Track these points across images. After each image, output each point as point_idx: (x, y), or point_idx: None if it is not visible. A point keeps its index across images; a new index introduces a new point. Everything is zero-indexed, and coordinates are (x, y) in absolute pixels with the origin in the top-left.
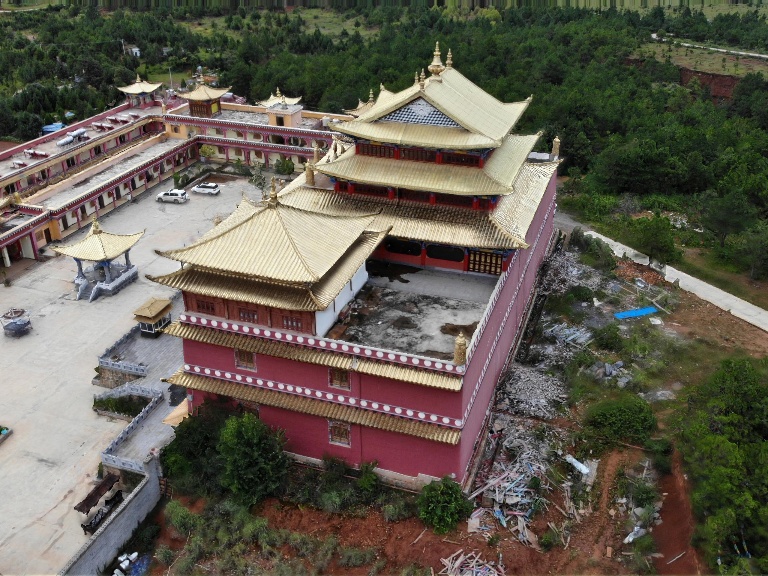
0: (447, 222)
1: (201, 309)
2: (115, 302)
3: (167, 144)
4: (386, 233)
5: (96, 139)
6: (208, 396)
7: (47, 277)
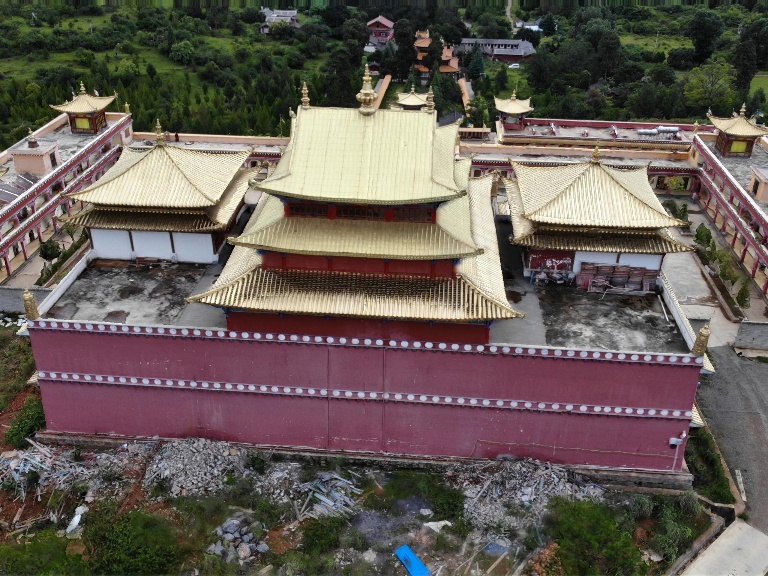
0: (252, 252)
1: None
2: None
3: (669, 163)
4: (222, 227)
5: (686, 143)
6: None
7: None
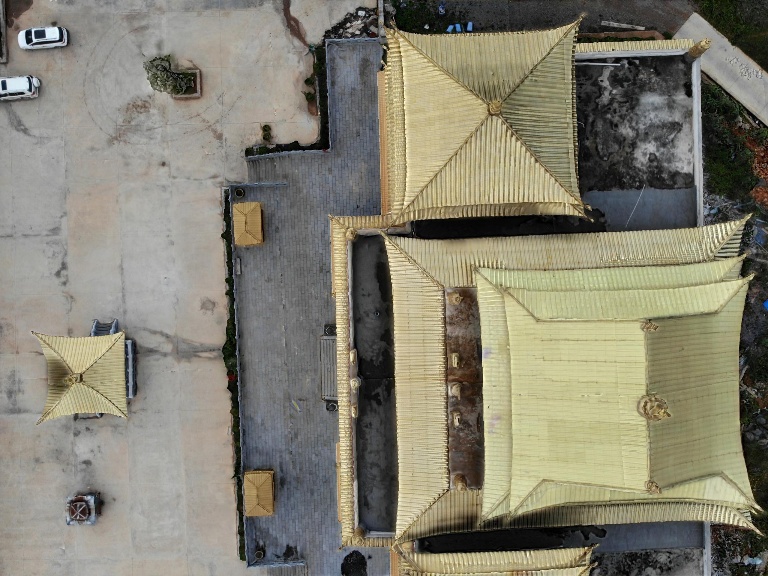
0: None
1: None
2: (149, 407)
3: None
4: None
5: None
6: None
7: (18, 379)
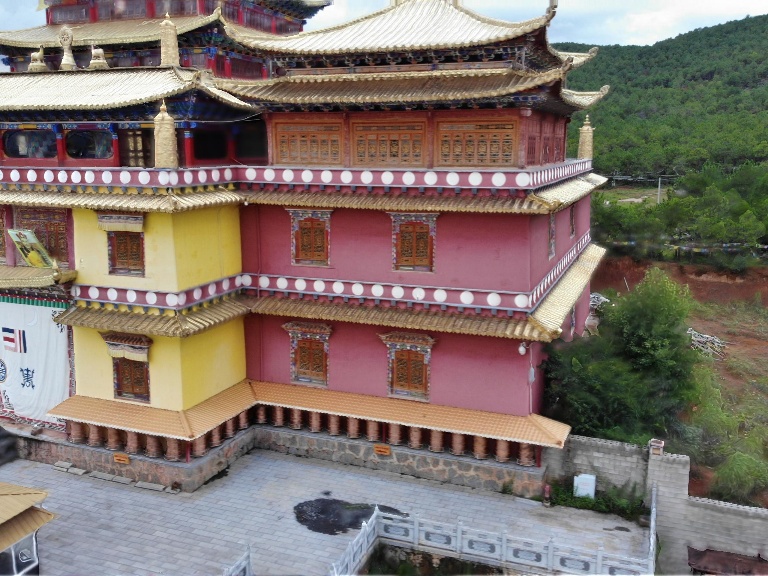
0: None
1: (529, 156)
2: None
3: None
4: None
5: None
6: (544, 346)
7: None
